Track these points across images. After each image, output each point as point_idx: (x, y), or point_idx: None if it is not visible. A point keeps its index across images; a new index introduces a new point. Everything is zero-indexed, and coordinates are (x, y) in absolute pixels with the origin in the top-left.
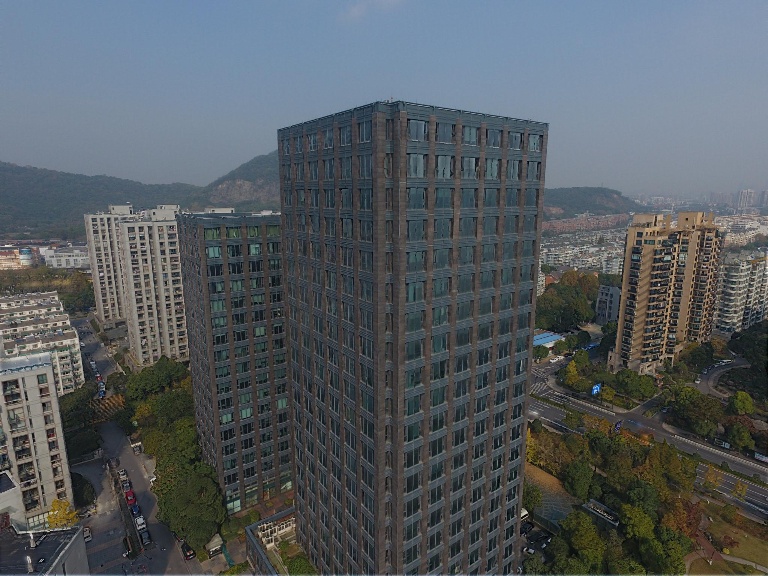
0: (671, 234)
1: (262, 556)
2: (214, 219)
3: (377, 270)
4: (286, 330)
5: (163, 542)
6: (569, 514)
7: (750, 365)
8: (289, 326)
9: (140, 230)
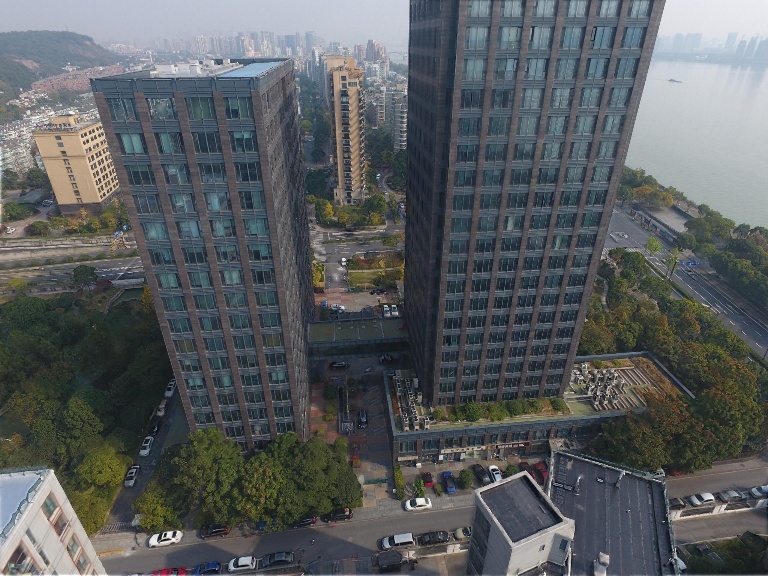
0: (358, 76)
1: (441, 431)
2: (262, 79)
3: (636, 102)
4: (446, 203)
5: (300, 541)
6: None
7: (390, 174)
8: (453, 197)
9: None
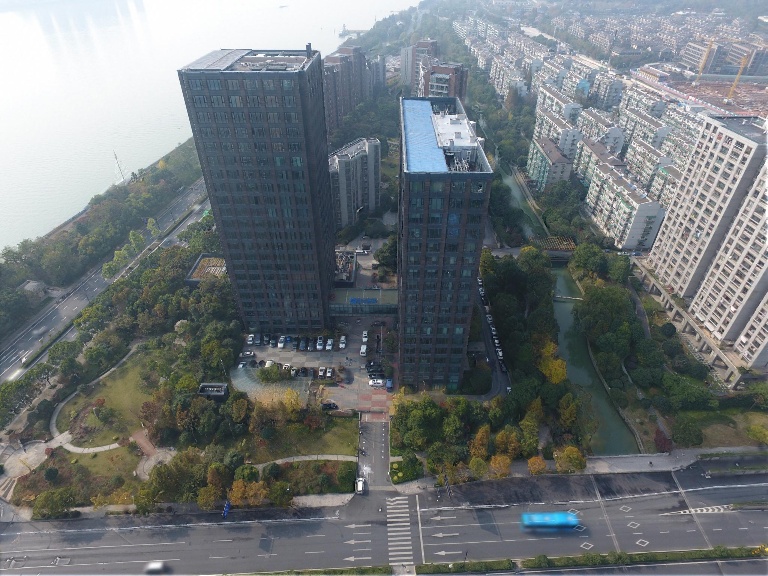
0: None
1: None
2: None
3: None
4: None
5: None
6: (227, 352)
7: None
8: None
9: (716, 130)
